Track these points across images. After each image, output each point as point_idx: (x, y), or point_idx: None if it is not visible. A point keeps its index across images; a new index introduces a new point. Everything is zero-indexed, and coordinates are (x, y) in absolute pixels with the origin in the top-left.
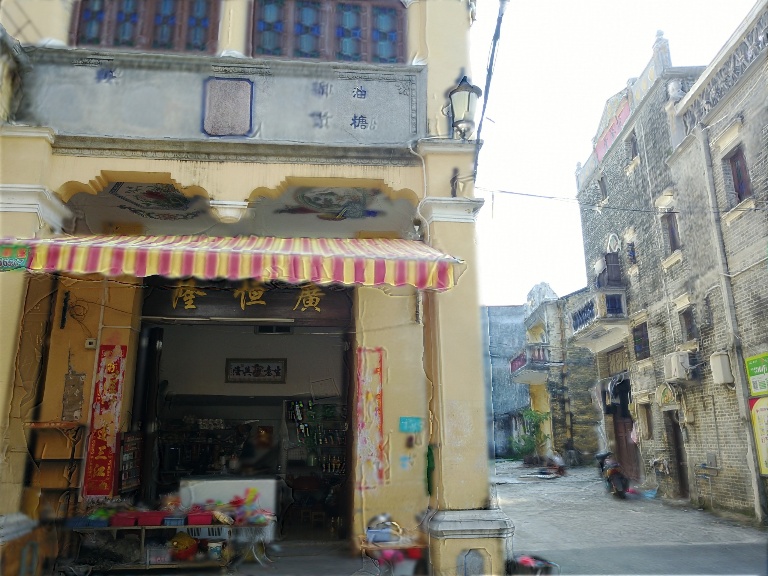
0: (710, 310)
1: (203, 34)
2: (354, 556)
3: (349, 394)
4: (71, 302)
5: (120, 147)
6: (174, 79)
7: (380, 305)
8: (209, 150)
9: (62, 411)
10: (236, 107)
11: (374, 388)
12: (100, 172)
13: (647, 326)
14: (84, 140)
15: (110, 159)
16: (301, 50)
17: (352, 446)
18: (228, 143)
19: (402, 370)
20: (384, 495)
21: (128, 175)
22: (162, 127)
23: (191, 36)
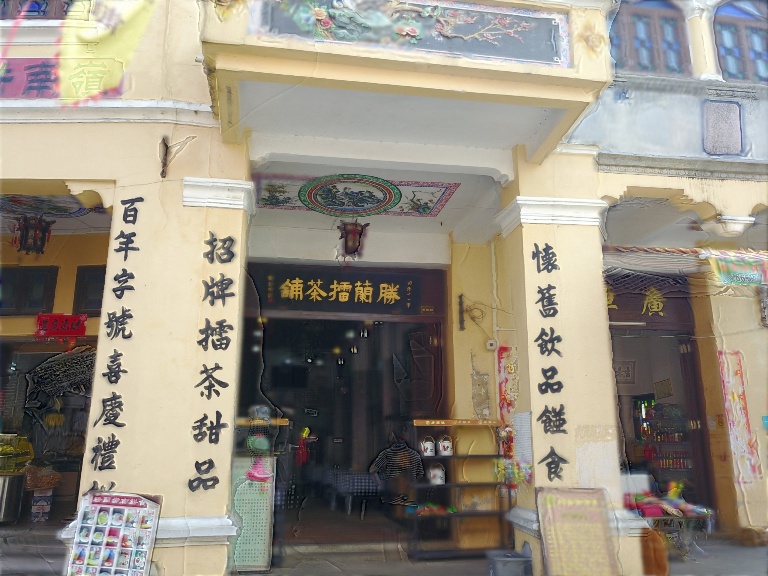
0: None
1: (676, 57)
2: (758, 546)
3: (698, 394)
4: (467, 305)
5: (643, 164)
6: (676, 101)
7: (731, 311)
8: (715, 168)
9: (474, 409)
10: (730, 128)
11: (737, 389)
12: (626, 188)
13: None
14: (615, 157)
15: (632, 175)
16: (759, 74)
17: (711, 443)
18: (733, 162)
19: (759, 372)
20: (760, 489)
21: (649, 191)
22: (671, 146)
23: (667, 59)
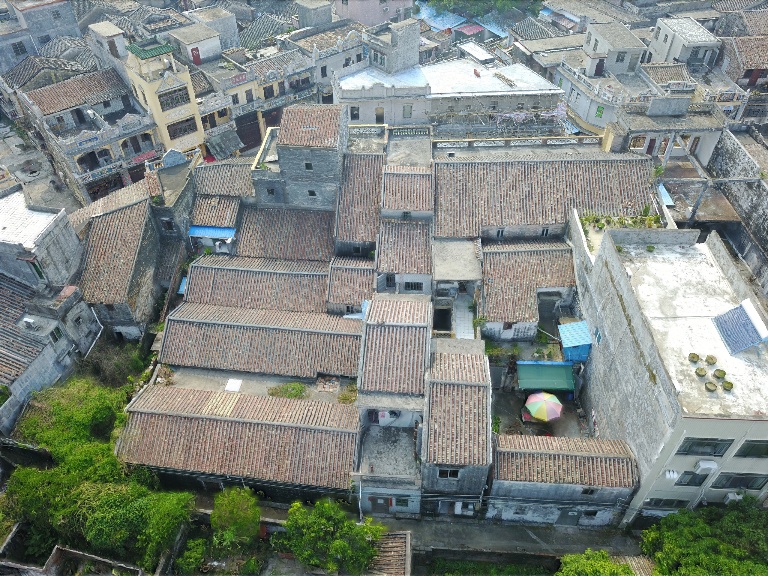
0: (64, 171)
1: None
2: None
3: None
4: None
5: None
6: None
7: None
8: None
9: None
10: None
11: None
12: None
13: (53, 157)
14: None
15: None
16: None
17: None
18: None
19: None
20: None
21: None
22: None
23: None
